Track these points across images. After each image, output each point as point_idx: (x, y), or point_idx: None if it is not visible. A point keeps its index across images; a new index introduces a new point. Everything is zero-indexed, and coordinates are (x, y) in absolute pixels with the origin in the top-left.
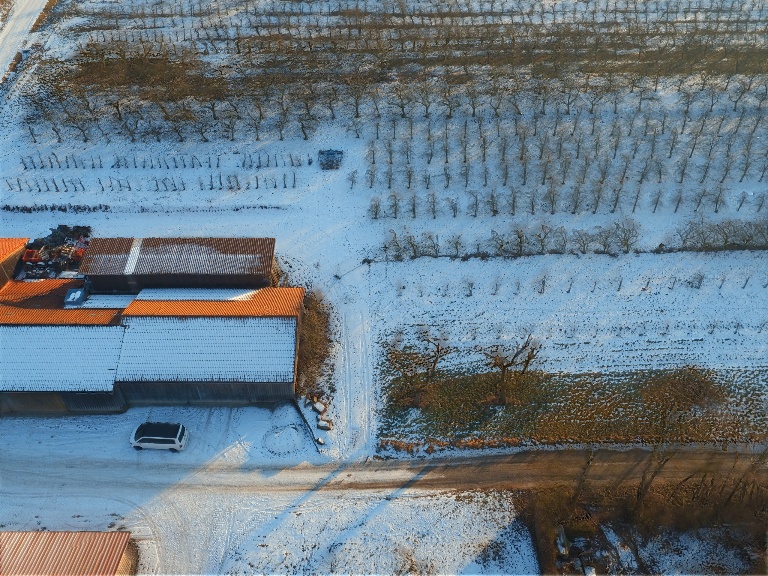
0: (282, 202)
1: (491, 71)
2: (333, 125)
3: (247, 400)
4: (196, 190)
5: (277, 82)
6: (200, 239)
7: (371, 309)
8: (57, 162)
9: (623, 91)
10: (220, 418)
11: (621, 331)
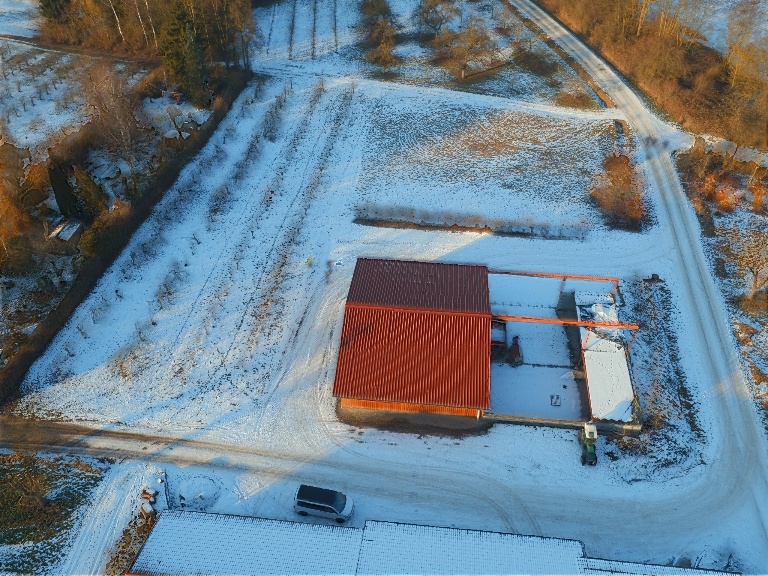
0: None
1: None
2: None
3: None
4: None
5: None
6: None
7: None
8: None
9: None
10: None
11: None
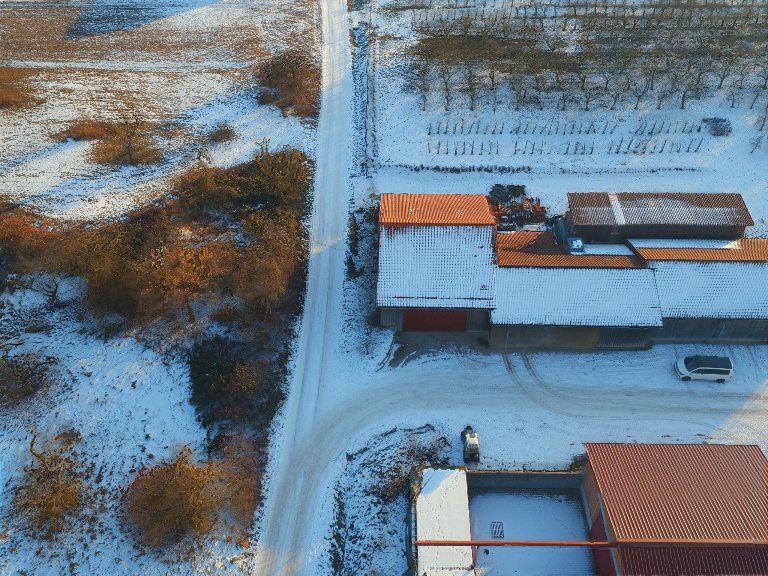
0: (695, 165)
1: None
2: (701, 96)
3: (761, 339)
4: (603, 154)
5: (621, 57)
6: (670, 194)
7: None
8: (461, 128)
9: None
10: (743, 354)
11: None
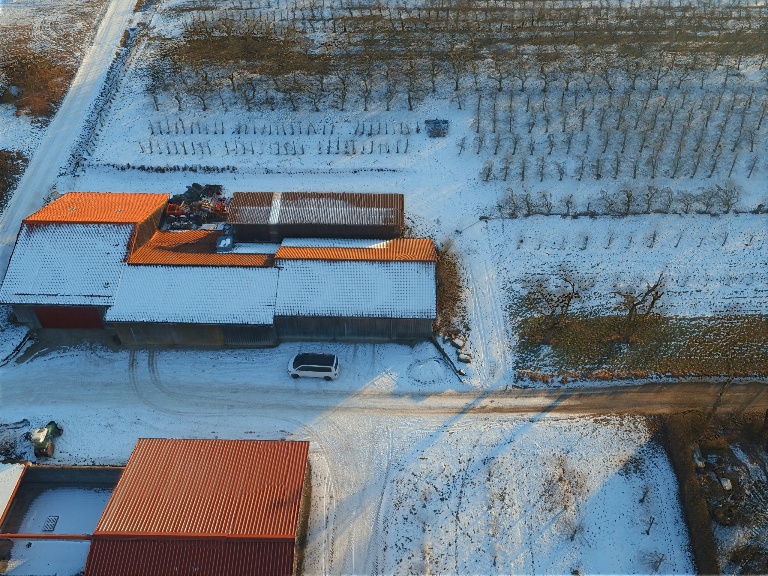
0: (397, 165)
1: (578, 50)
2: (435, 97)
3: (388, 337)
4: (314, 154)
5: (376, 58)
6: (334, 194)
7: (493, 260)
8: (182, 128)
9: (707, 69)
10: (365, 352)
11: (729, 281)
